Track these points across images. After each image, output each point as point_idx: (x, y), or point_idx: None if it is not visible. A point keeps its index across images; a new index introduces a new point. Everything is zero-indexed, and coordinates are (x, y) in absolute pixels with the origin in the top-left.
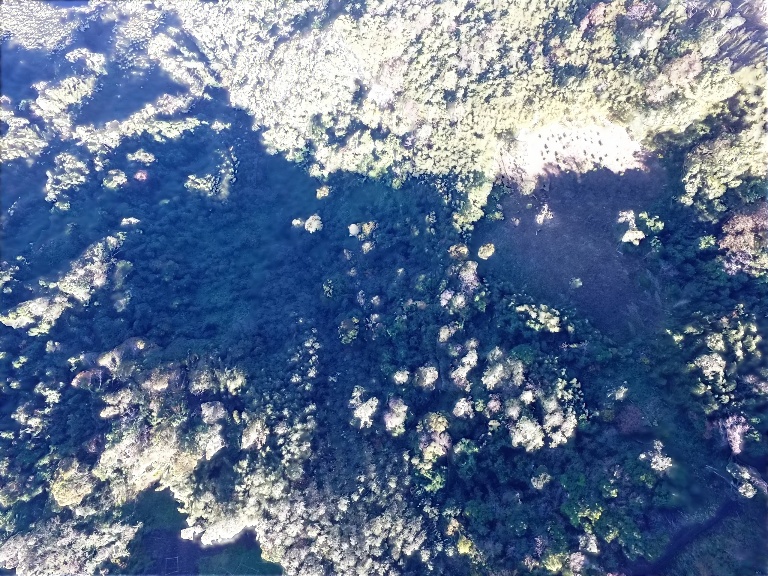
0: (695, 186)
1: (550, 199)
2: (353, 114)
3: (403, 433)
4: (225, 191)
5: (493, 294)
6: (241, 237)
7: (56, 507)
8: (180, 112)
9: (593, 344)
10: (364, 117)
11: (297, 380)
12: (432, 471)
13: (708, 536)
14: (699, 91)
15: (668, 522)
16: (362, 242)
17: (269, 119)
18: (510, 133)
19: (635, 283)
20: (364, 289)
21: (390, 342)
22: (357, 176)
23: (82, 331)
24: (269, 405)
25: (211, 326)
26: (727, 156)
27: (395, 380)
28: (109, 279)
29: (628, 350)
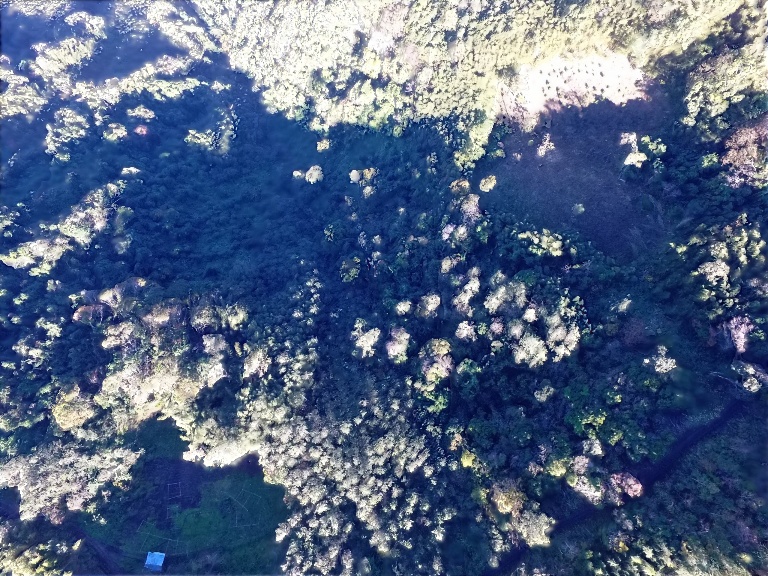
0: (698, 104)
1: (552, 136)
2: (353, 66)
3: (405, 361)
4: (225, 146)
5: (495, 225)
6: (242, 190)
7: (58, 431)
8: (180, 74)
9: (596, 264)
10: (364, 66)
11: (299, 315)
12: (435, 393)
13: (713, 437)
14: (701, 6)
15: (672, 425)
16: (363, 187)
17: (269, 78)
18: (511, 69)
19: (638, 208)
20: (365, 232)
21: (392, 279)
22: (358, 128)
23: (83, 273)
24: (271, 337)
25: (212, 271)
26: (730, 69)
27: (397, 311)
28: (110, 224)
29: (631, 268)
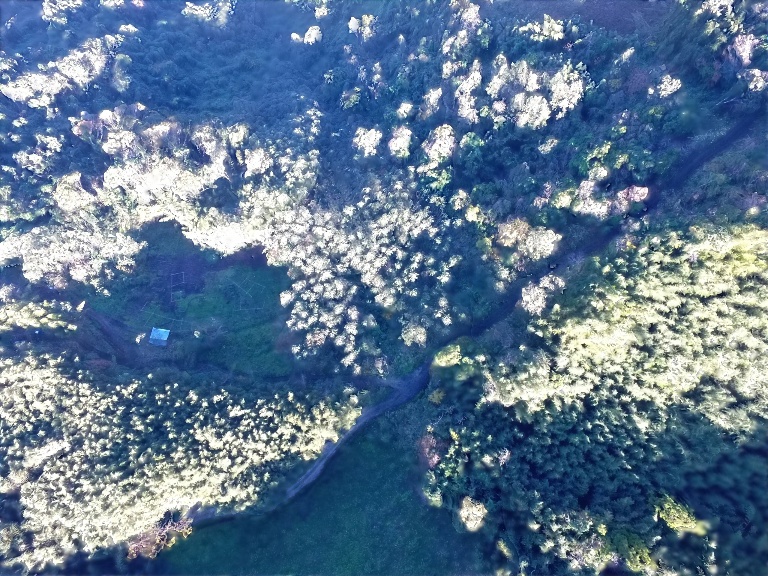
0: None
1: None
2: None
3: (408, 156)
4: (223, 18)
5: (496, 28)
6: (240, 57)
7: (60, 219)
8: None
9: None
10: None
11: (300, 132)
12: (438, 170)
13: (719, 156)
14: None
15: (678, 147)
16: (362, 33)
17: None
18: None
19: None
20: None
21: None
22: None
23: (82, 109)
24: (272, 146)
25: None
26: None
27: (398, 114)
28: (108, 69)
29: (634, 34)
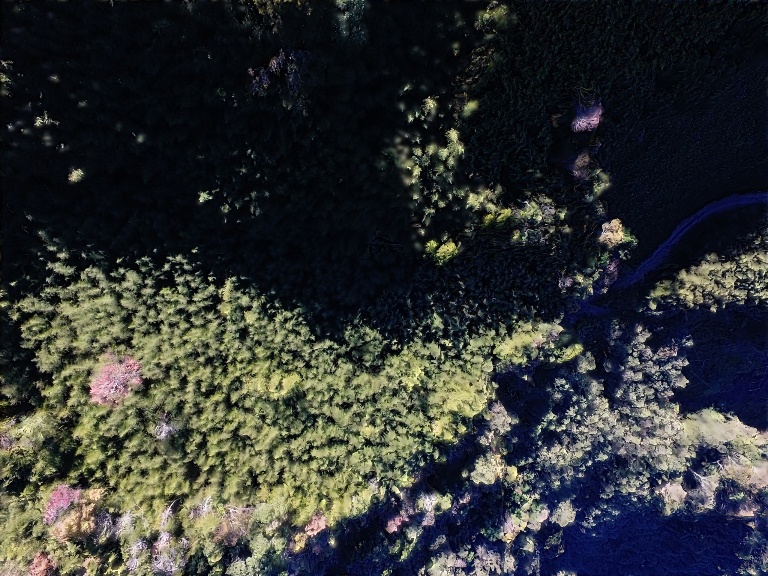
0: None
1: None
2: None
3: (533, 504)
4: None
5: None
6: None
7: None
8: None
9: None
10: None
11: (614, 512)
12: None
13: None
14: None
15: None
16: None
17: None
18: None
19: None
20: None
21: None
22: None
23: None
24: None
25: None
26: None
27: None
28: (760, 547)
29: None
